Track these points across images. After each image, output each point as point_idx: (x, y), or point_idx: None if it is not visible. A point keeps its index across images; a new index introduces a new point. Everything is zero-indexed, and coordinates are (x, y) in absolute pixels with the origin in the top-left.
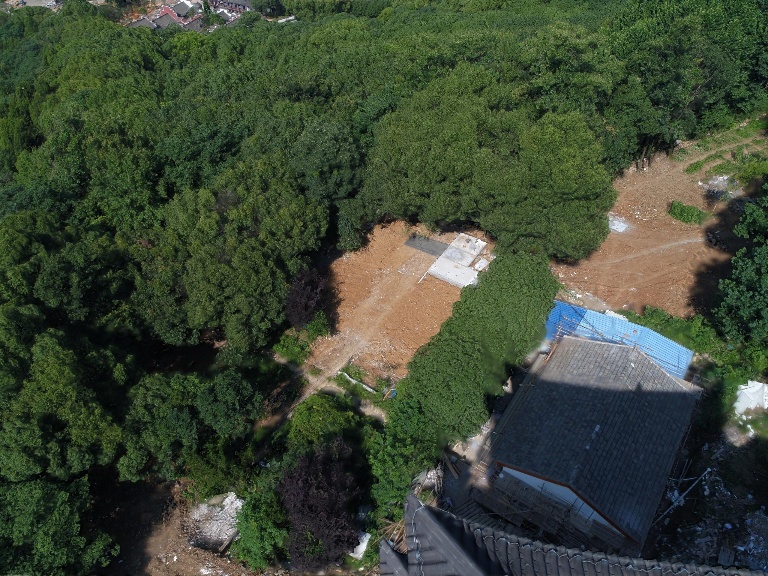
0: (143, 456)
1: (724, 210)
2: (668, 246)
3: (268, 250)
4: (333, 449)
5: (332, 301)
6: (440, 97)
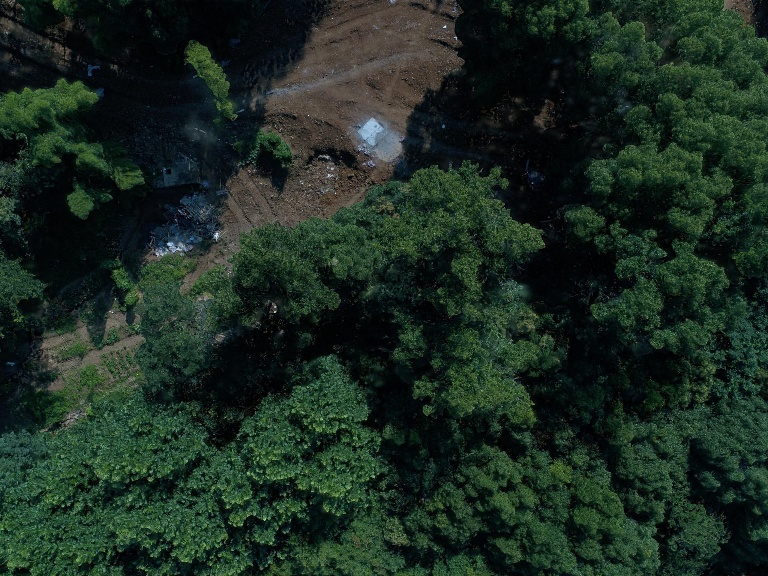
0: None
1: (211, 162)
2: (320, 81)
3: None
4: None
5: (761, 23)
6: (735, 137)
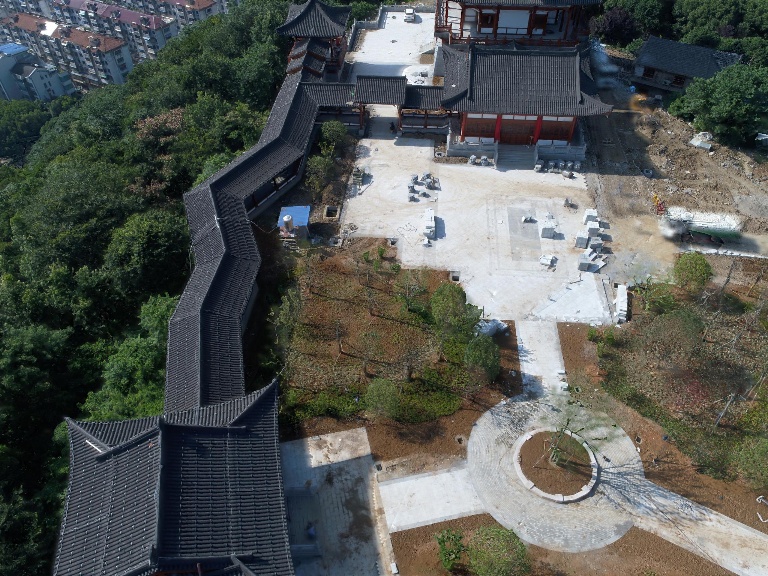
0: (614, 3)
1: None
2: None
3: (741, 5)
4: (640, 27)
5: None
6: None
